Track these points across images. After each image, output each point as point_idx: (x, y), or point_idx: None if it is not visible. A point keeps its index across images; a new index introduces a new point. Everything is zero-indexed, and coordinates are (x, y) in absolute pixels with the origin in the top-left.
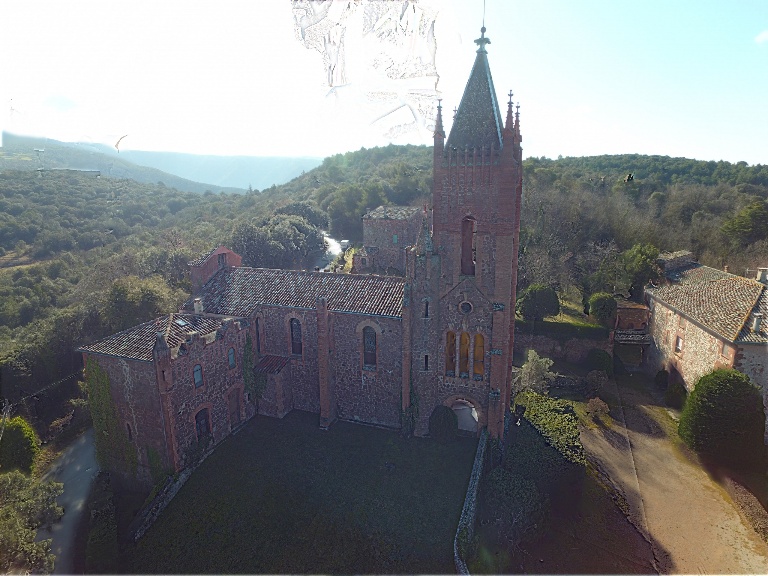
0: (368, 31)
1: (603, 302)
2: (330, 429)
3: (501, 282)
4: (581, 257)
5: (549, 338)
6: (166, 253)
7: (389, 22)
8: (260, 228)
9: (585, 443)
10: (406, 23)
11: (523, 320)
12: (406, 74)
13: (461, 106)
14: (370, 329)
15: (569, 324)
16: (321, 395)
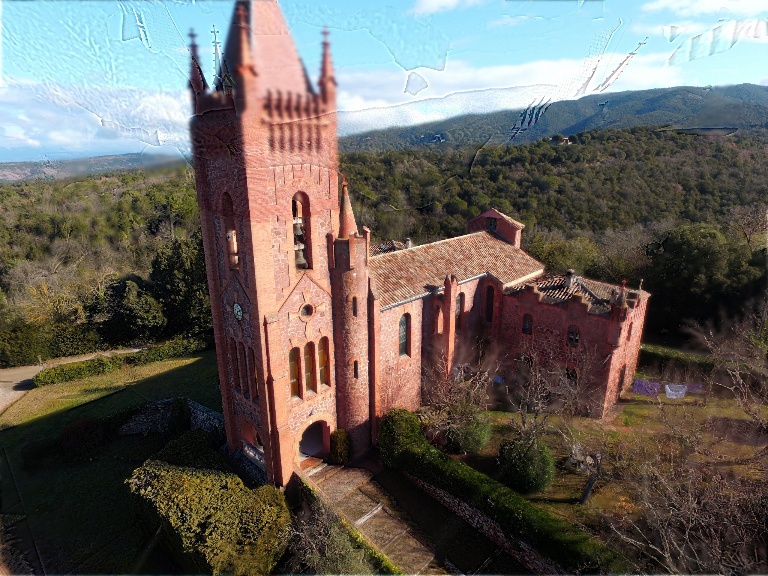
0: None
1: None
2: None
3: None
4: None
5: None
6: (691, 232)
7: None
8: None
9: None
10: None
11: None
12: None
13: None
14: None
15: None
16: None
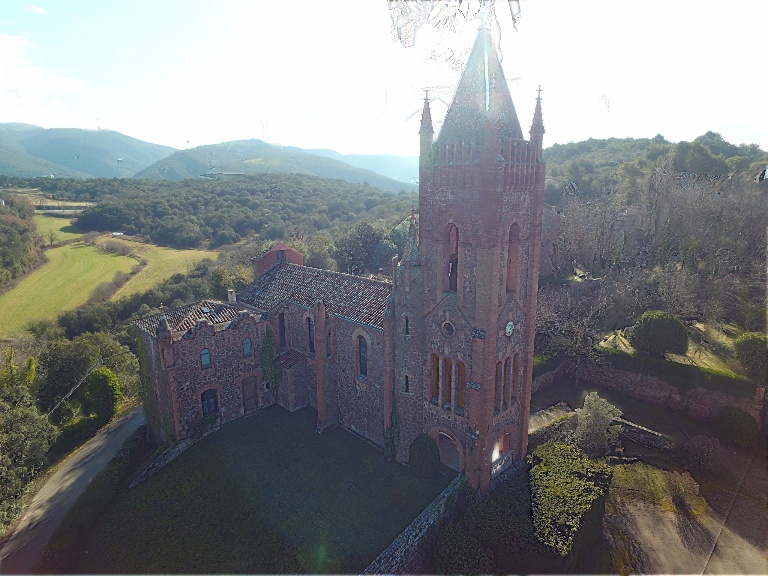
0: (423, 22)
1: (753, 346)
2: (324, 433)
3: (482, 304)
4: (738, 281)
5: (664, 381)
6: None
7: (446, 9)
8: None
9: (640, 527)
10: (467, 7)
11: (632, 354)
12: None
13: (455, 96)
14: (364, 338)
15: (695, 368)
16: (318, 397)
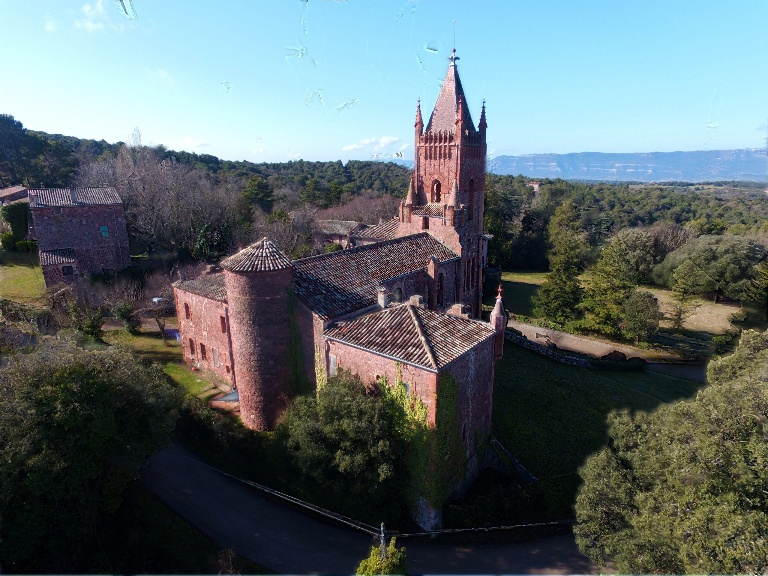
0: None
1: None
2: None
3: None
4: None
5: None
6: None
7: None
8: None
9: None
10: None
11: None
12: None
13: None
14: None
15: None
16: None
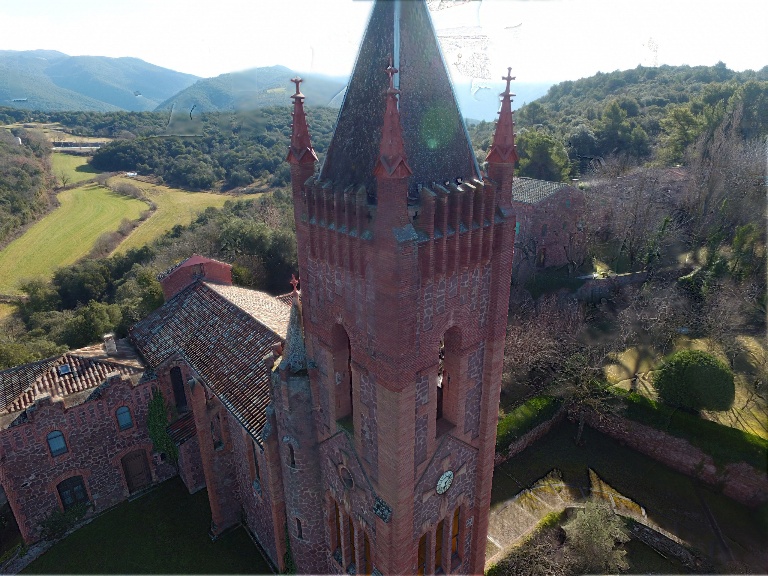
0: None
1: None
2: (218, 540)
3: (386, 469)
4: None
5: (695, 447)
6: (243, 228)
7: None
8: None
9: None
10: None
11: (655, 403)
12: (447, 0)
13: (348, 91)
14: None
15: (741, 437)
16: (209, 495)
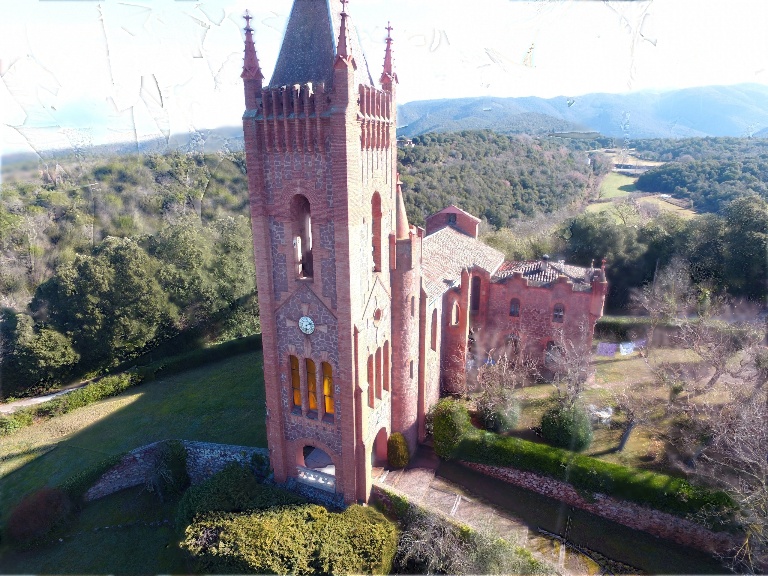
0: None
1: None
2: None
3: None
4: None
5: None
6: None
7: None
8: (765, 211)
9: None
10: None
11: None
12: None
13: None
14: None
15: None
16: None
